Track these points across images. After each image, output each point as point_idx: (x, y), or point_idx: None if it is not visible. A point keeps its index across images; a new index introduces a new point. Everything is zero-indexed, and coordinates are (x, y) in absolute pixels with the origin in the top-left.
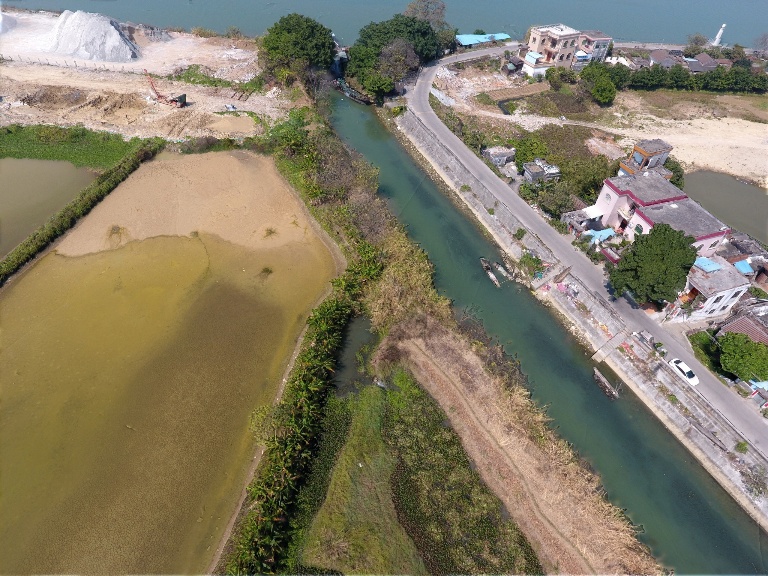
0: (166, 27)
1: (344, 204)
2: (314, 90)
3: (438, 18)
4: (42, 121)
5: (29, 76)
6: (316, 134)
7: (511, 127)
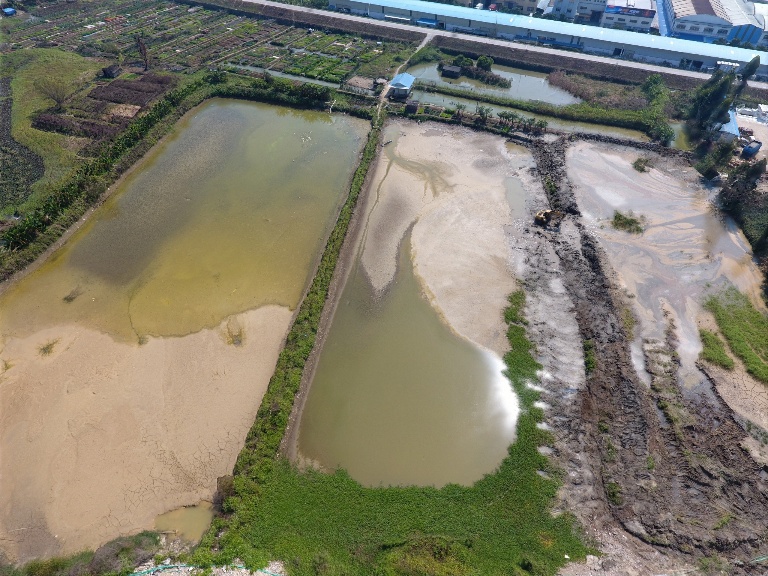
0: None
1: None
2: None
3: None
4: None
5: None
6: None
7: None
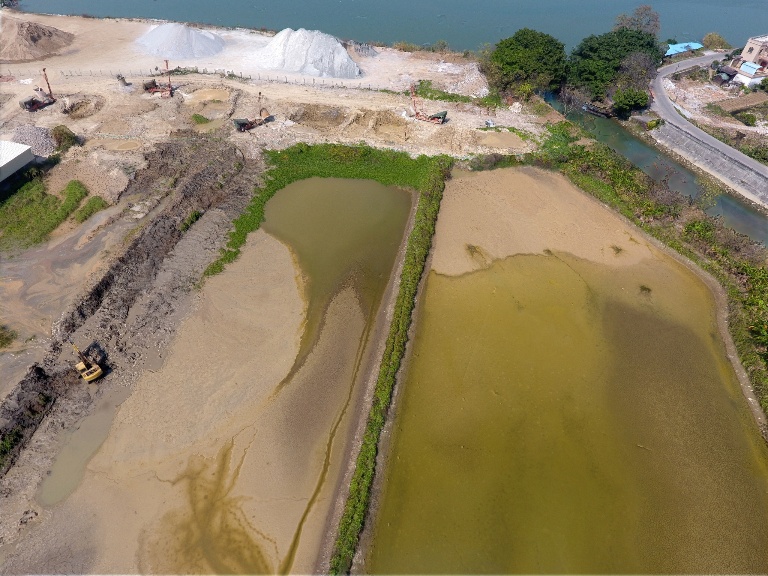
0: (367, 42)
1: (677, 221)
2: (563, 105)
3: (647, 29)
4: (326, 140)
5: (278, 94)
6: (602, 150)
7: (764, 139)
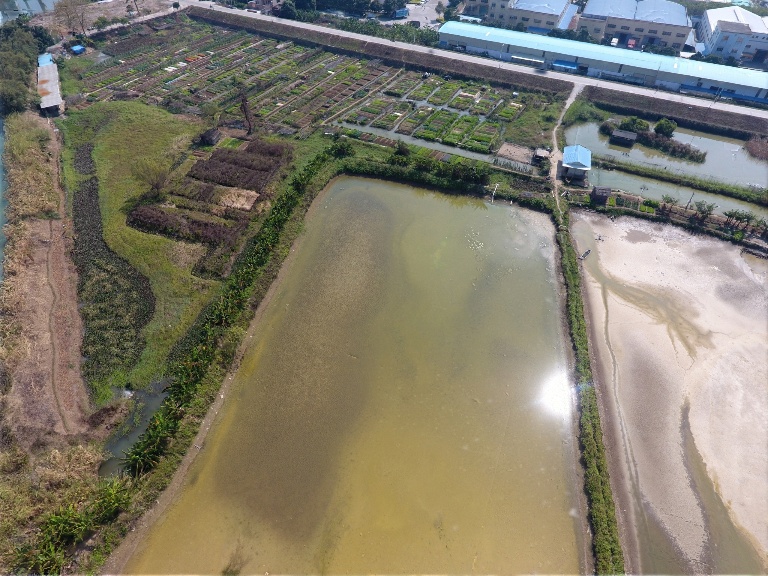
0: None
1: None
2: None
3: None
4: None
5: None
6: None
7: None
